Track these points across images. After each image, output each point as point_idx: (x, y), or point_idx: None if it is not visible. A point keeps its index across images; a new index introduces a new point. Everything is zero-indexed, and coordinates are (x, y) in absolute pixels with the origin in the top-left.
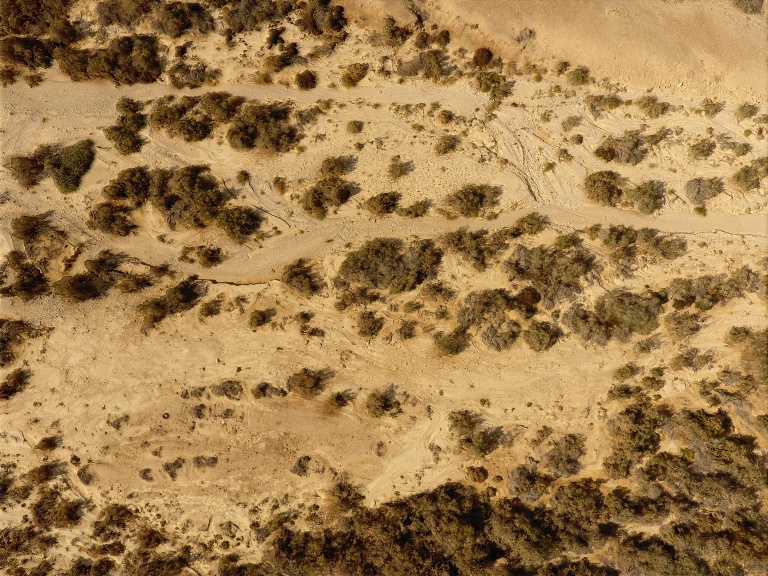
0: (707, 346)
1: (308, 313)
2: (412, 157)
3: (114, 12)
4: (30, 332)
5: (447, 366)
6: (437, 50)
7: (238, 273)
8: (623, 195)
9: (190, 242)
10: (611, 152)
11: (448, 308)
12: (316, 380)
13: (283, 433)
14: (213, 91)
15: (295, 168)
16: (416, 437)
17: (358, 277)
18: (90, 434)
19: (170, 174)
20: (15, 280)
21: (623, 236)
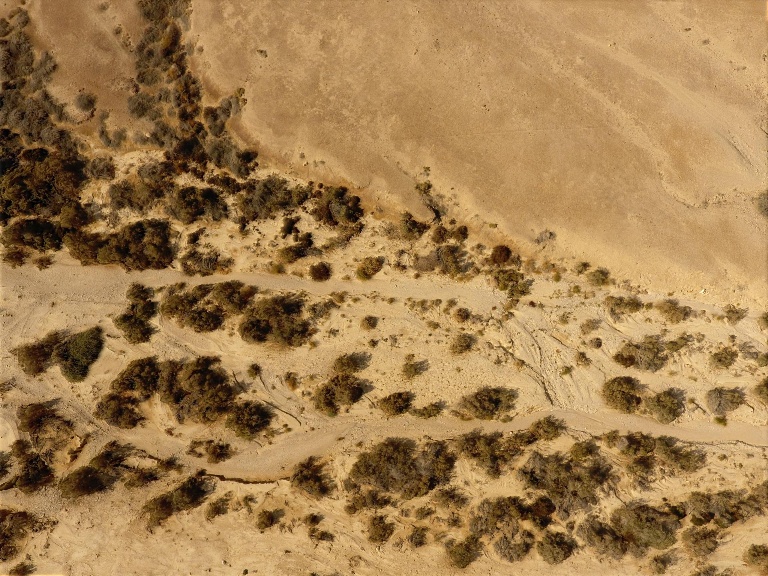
0: (725, 564)
1: (317, 515)
2: (427, 356)
3: (126, 196)
4: (34, 526)
5: None
6: (455, 247)
7: (247, 469)
8: (642, 403)
9: (198, 436)
10: (630, 359)
11: (460, 515)
12: None
13: None
14: (225, 281)
15: (307, 363)
16: None
17: (369, 481)
18: None
19: (180, 366)
20: (20, 472)
21: (641, 448)
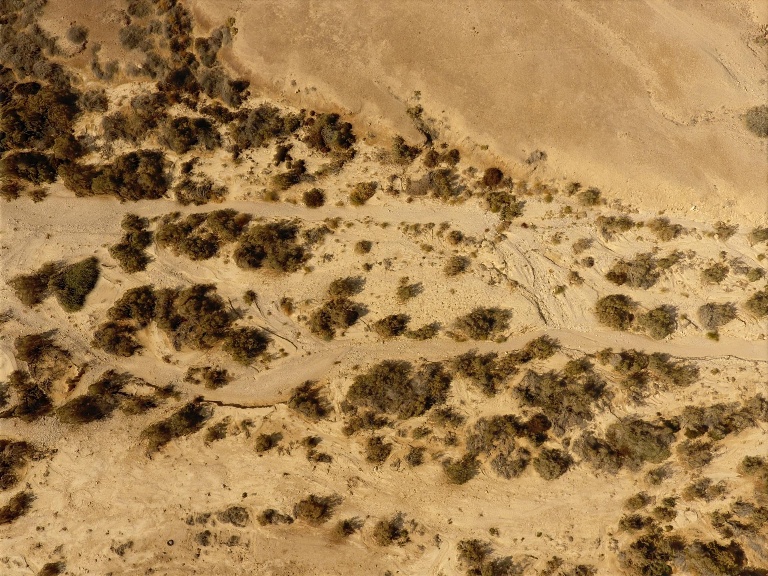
0: (720, 476)
1: (315, 438)
2: (421, 278)
3: (119, 127)
4: (33, 454)
5: (456, 494)
6: (447, 170)
7: (244, 395)
8: (635, 320)
9: (196, 363)
10: (623, 277)
11: (457, 434)
12: (323, 508)
13: (289, 561)
14: (219, 209)
15: (302, 288)
16: (424, 567)
17: (366, 402)
18: (93, 560)
19: (176, 294)
20: (18, 402)
21: (635, 363)
